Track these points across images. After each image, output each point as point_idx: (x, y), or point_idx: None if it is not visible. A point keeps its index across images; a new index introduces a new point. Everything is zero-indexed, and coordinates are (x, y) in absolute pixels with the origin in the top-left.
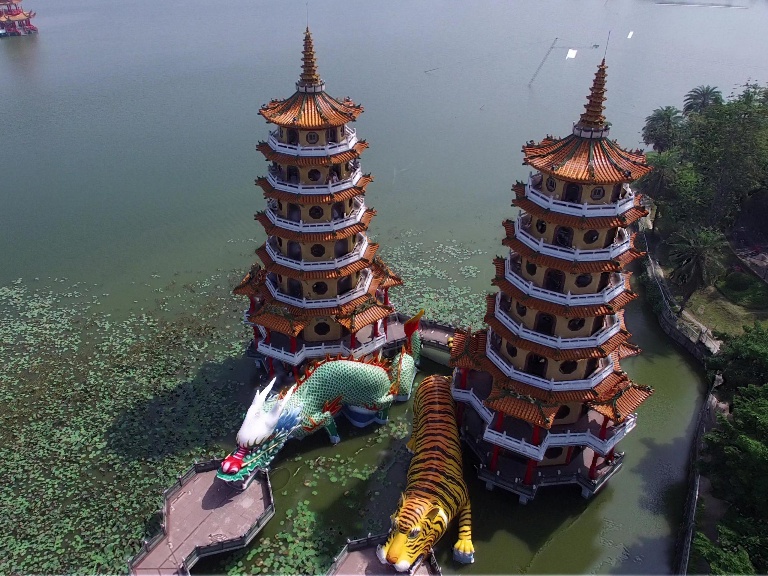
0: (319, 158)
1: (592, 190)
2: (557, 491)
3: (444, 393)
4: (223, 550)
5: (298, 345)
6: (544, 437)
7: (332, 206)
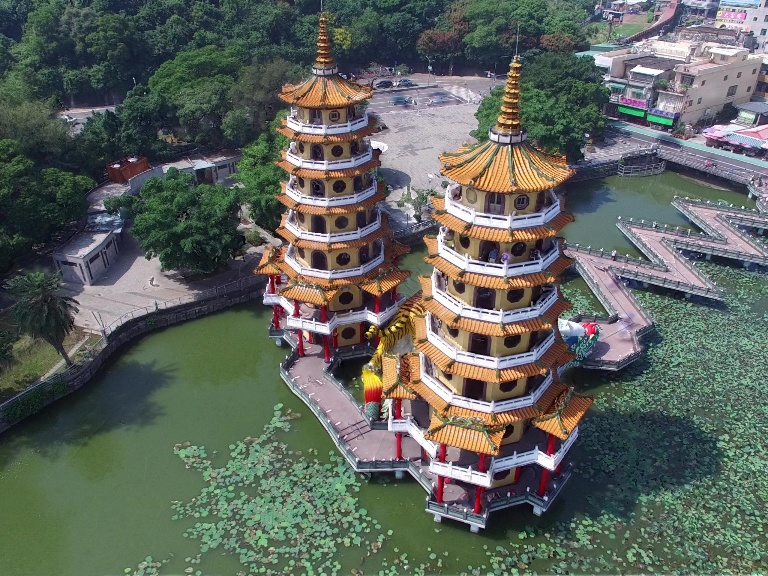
0: None
1: None
2: None
3: None
4: None
5: None
6: None
7: None
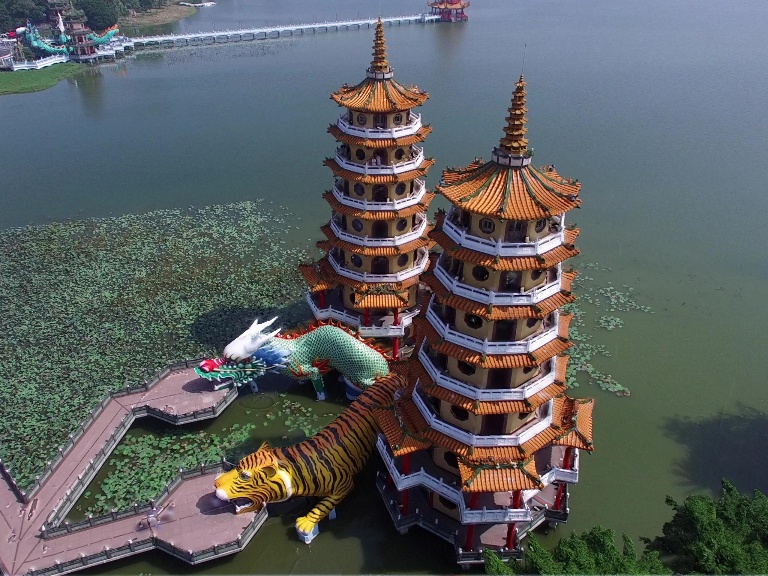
0: (360, 139)
1: (481, 220)
2: (433, 540)
3: (384, 392)
4: (163, 418)
5: (326, 303)
6: (415, 471)
7: (373, 187)
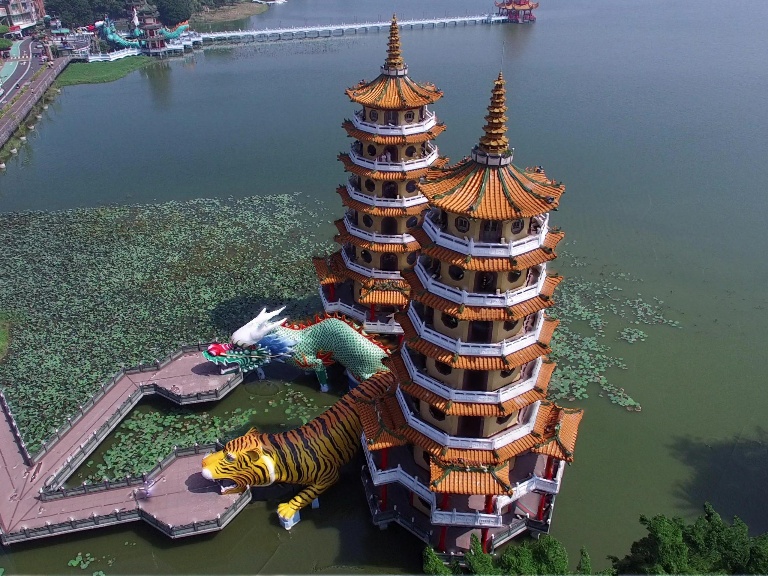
0: (370, 134)
1: (457, 218)
2: (410, 539)
3: (377, 387)
4: (169, 397)
5: (335, 297)
6: (393, 467)
7: (383, 184)
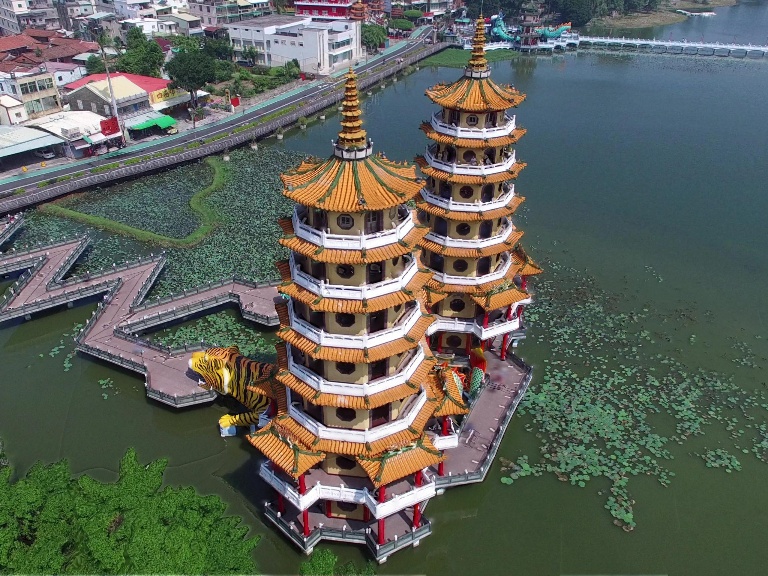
0: None
1: None
2: None
3: None
4: None
5: None
6: None
7: (441, 182)
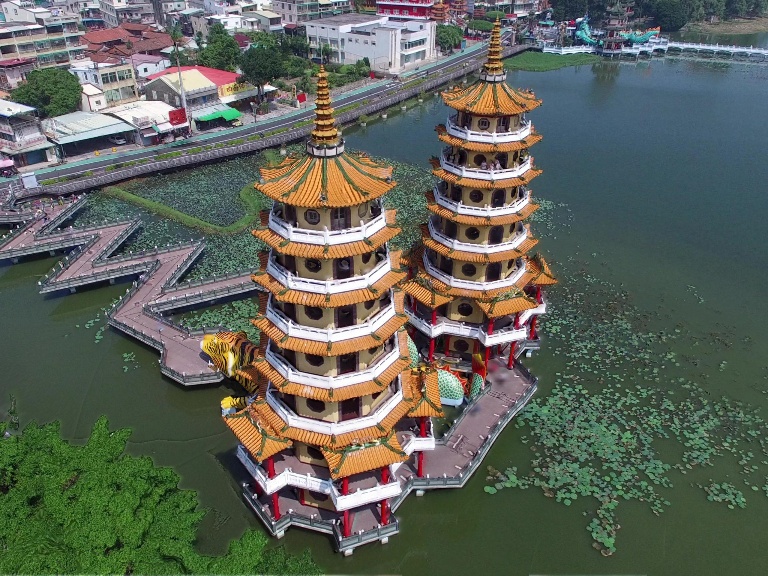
0: None
1: None
2: None
3: None
4: None
5: None
6: None
7: (452, 185)
